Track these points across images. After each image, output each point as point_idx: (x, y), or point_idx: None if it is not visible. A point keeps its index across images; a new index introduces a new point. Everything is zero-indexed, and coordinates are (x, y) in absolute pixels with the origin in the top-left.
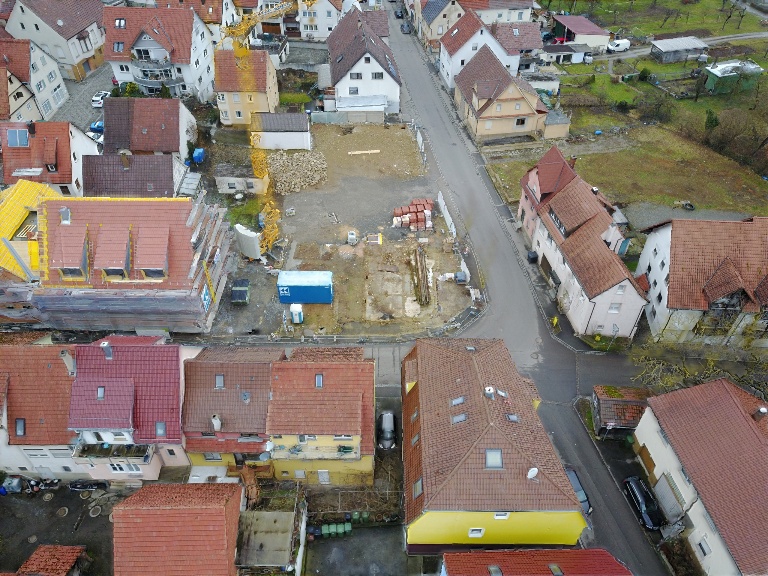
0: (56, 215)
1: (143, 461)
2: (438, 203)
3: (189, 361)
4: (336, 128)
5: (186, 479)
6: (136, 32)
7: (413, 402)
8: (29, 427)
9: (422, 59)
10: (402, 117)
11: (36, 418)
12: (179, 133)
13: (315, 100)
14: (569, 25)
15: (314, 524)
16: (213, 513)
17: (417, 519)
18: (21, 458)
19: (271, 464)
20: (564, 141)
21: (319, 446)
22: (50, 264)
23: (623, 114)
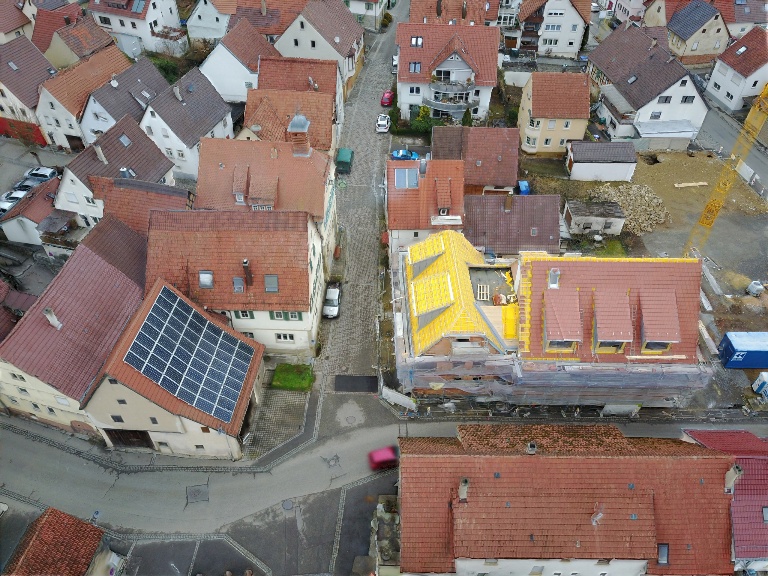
0: (543, 278)
1: None
2: None
3: None
4: (637, 156)
5: None
6: (435, 51)
7: None
8: (672, 554)
9: None
10: (701, 143)
11: (682, 543)
12: None
13: (594, 123)
14: None
15: None
16: None
17: None
18: None
19: None
20: None
21: None
22: None
23: None
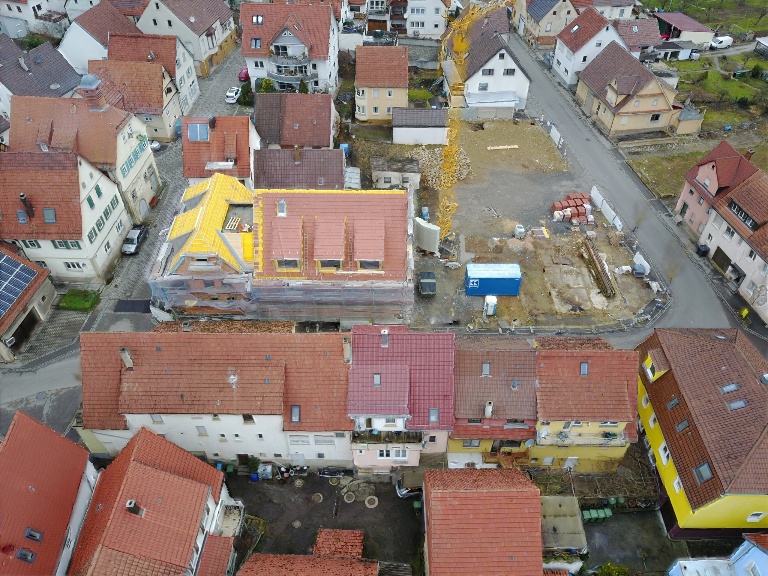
0: (272, 207)
1: (420, 447)
2: (591, 197)
3: (455, 349)
4: (466, 124)
5: (446, 465)
6: (273, 28)
7: (666, 390)
8: (304, 414)
9: (530, 56)
10: (528, 113)
11: (311, 405)
12: (330, 128)
13: (437, 96)
14: (673, 22)
15: None
16: (529, 496)
17: (711, 503)
18: (282, 445)
19: (527, 451)
20: (697, 137)
21: (582, 433)
22: (266, 256)
23: (745, 110)
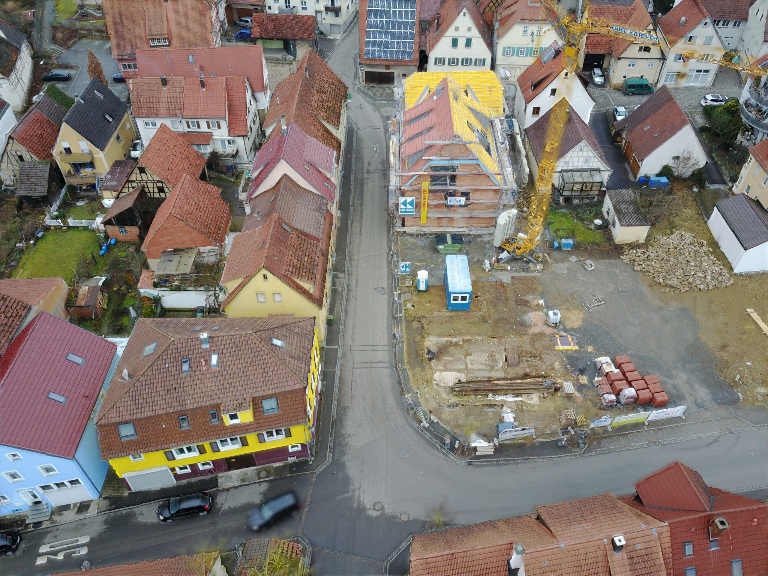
0: None
1: None
2: None
3: (285, 176)
4: None
5: None
6: None
7: None
8: None
9: None
10: None
11: None
12: (657, 148)
13: None
14: None
15: (210, 312)
16: None
17: None
18: None
19: None
20: None
21: None
22: None
23: None
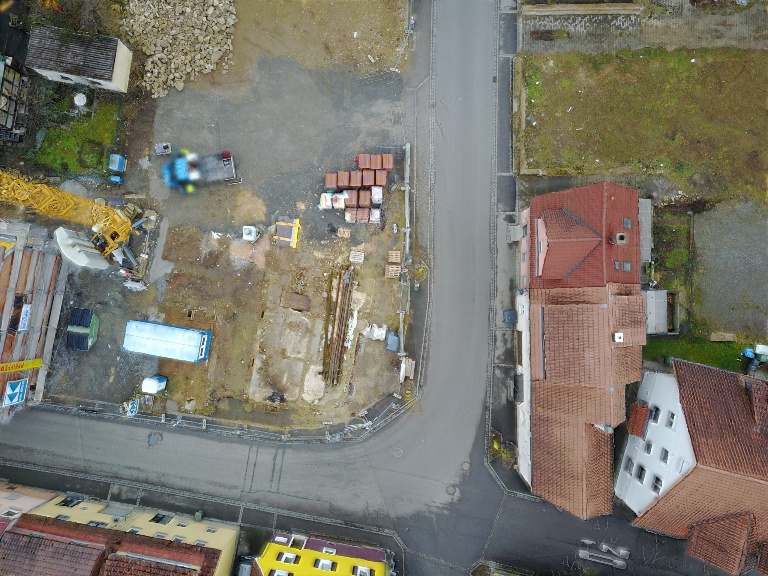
0: None
1: None
2: (404, 156)
3: None
4: None
5: None
6: None
7: None
8: None
9: None
10: None
11: None
12: None
13: None
14: None
15: None
16: None
17: None
18: None
19: None
20: None
21: None
22: None
23: None
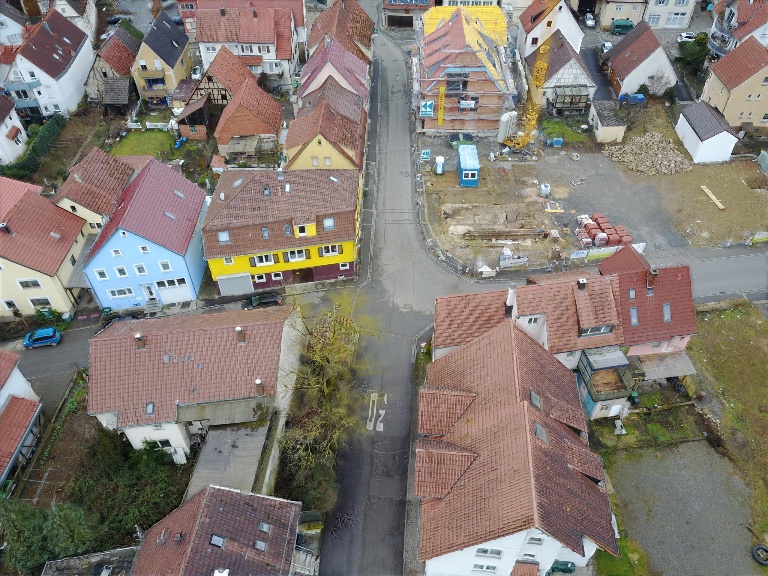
0: None
1: None
2: None
3: (330, 77)
4: (759, 179)
5: None
6: None
7: None
8: None
9: None
10: None
11: None
12: (635, 69)
13: None
14: None
15: None
16: None
17: None
18: None
19: None
20: None
21: None
22: None
23: None
